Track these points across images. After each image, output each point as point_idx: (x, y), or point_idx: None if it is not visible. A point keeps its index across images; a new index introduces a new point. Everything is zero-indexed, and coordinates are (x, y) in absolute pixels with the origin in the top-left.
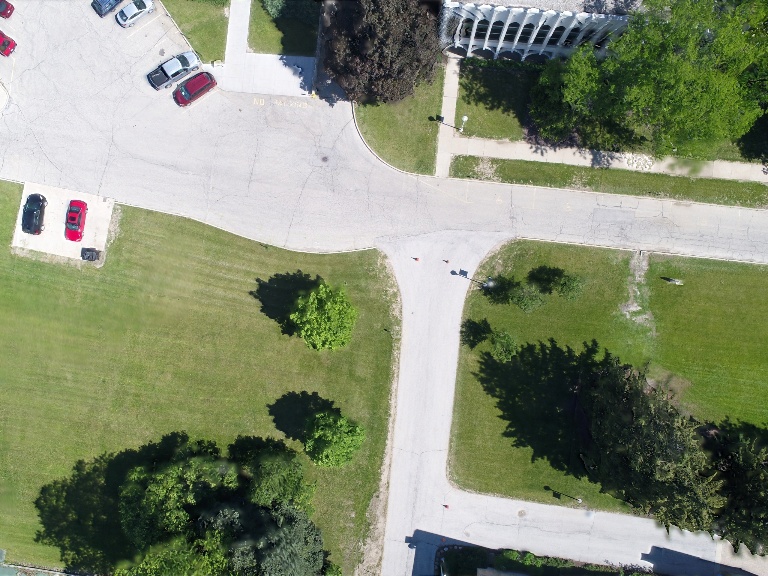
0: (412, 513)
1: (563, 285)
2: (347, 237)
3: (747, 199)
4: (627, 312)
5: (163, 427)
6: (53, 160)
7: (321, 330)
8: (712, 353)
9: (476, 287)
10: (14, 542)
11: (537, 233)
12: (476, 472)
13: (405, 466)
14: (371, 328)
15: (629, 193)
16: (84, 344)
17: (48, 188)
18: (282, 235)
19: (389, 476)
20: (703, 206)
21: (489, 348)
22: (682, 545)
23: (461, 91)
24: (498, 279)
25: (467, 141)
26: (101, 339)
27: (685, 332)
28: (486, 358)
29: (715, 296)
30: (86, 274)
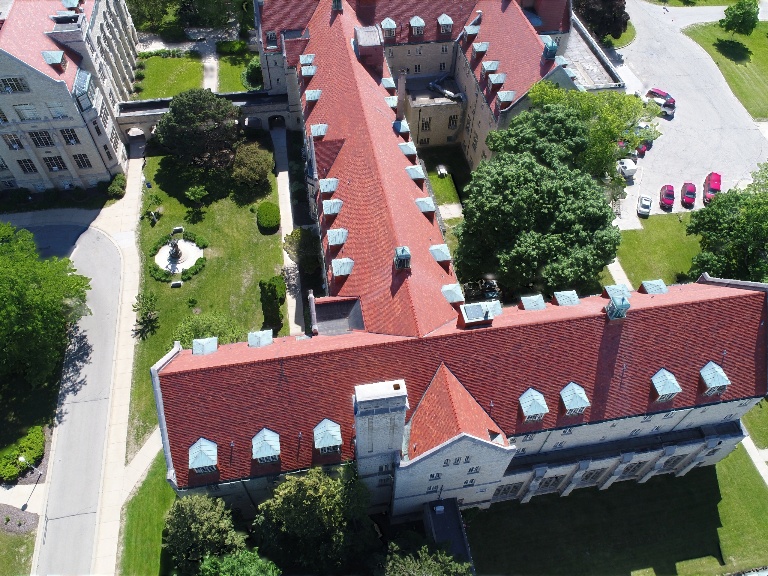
0: None
1: None
2: (684, 41)
3: None
4: None
5: None
6: (759, 152)
7: None
8: None
9: (667, 5)
10: None
11: None
12: None
13: None
14: None
15: None
16: None
17: None
18: (705, 60)
19: None
20: None
21: None
22: None
23: None
24: None
25: None
26: None
27: None
28: None
29: None
30: None
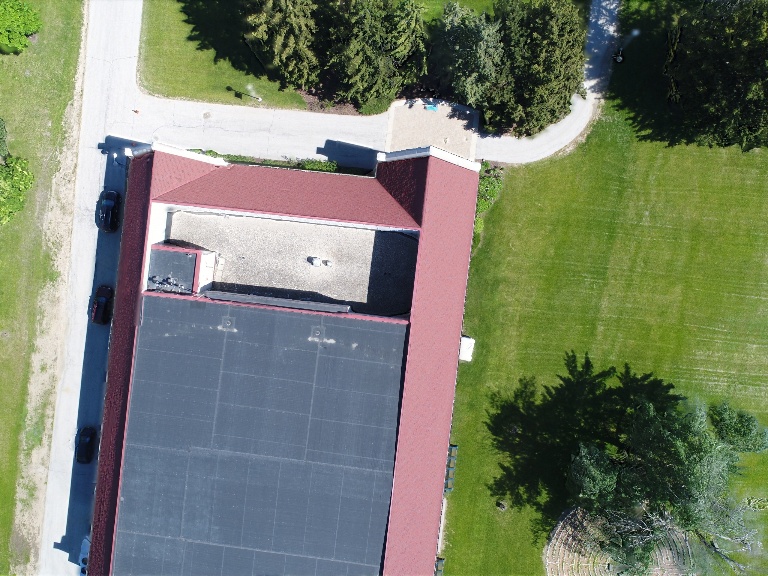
0: (105, 120)
1: None
2: None
3: None
4: None
5: None
6: None
7: None
8: None
9: None
10: None
11: None
12: (164, 77)
13: (98, 74)
14: None
15: None
16: None
17: None
18: None
19: (83, 84)
20: None
21: None
22: (355, 137)
23: None
24: None
25: None
26: None
27: None
28: None
29: None
30: None
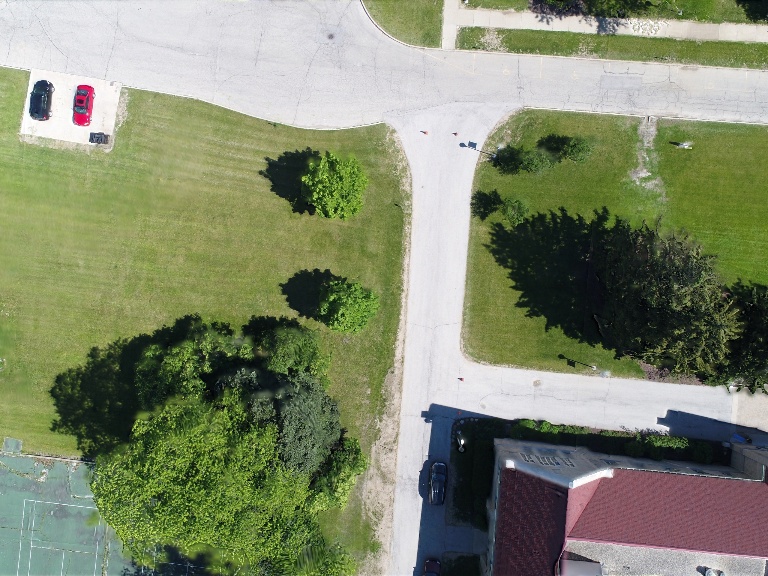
0: (427, 387)
1: (573, 147)
2: (355, 113)
3: (753, 60)
4: (637, 178)
5: (176, 310)
6: (59, 46)
7: (333, 188)
8: (722, 216)
9: (485, 158)
10: (30, 432)
11: (545, 102)
12: (490, 344)
13: (419, 341)
14: (382, 203)
15: (636, 59)
16: (95, 230)
17: (55, 74)
18: (290, 113)
19: (403, 351)
20: (710, 69)
21: (500, 219)
22: (697, 408)
23: None
24: (507, 150)
25: (473, 12)
26: (112, 224)
27: (695, 196)
28: (497, 229)
29: (724, 159)
30: (95, 159)
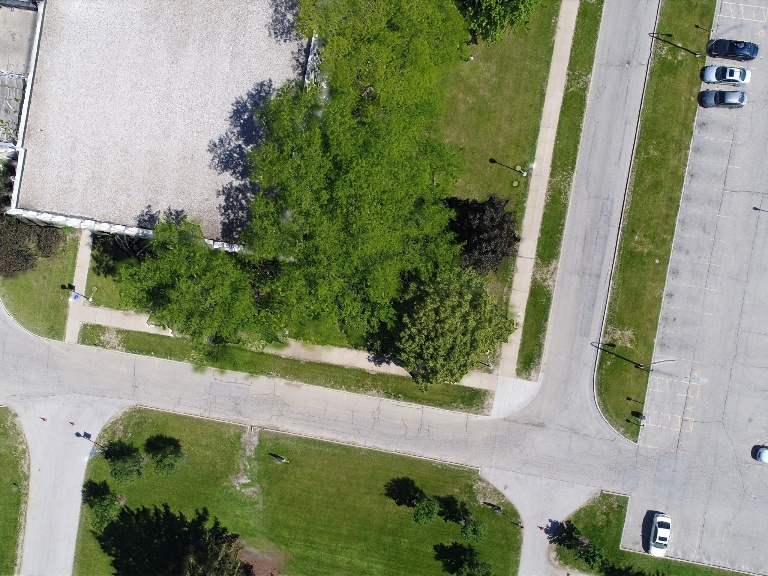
0: None
1: (159, 462)
2: None
3: (352, 385)
4: (237, 484)
5: None
6: None
7: None
8: (314, 529)
9: (98, 450)
10: None
11: (157, 402)
12: None
13: None
14: (1, 481)
15: (243, 371)
16: None
17: None
18: None
19: None
20: (312, 388)
21: None
22: None
23: (92, 262)
24: (118, 444)
25: (95, 310)
26: None
27: (290, 507)
28: None
29: (318, 475)
30: None
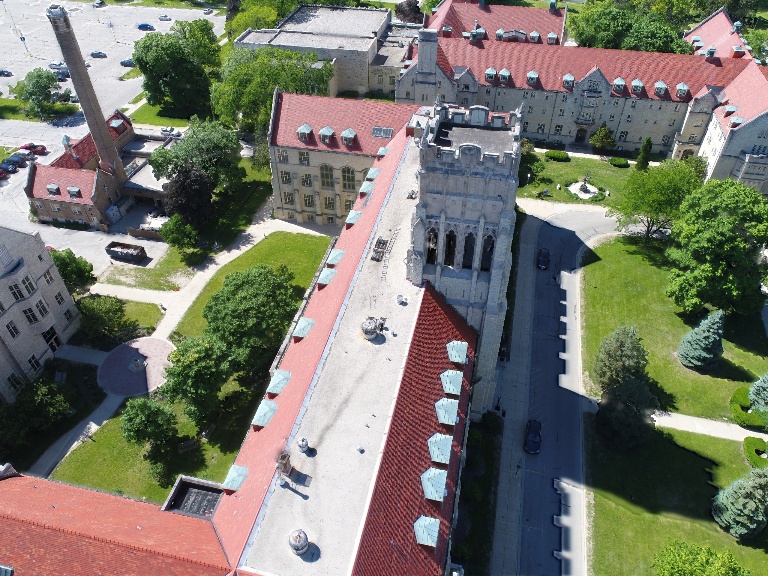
0: None
1: None
2: None
3: None
4: None
5: None
6: None
7: None
8: None
9: None
10: None
11: None
12: None
13: None
14: None
15: None
16: None
17: None
18: None
19: (420, 5)
20: None
21: None
22: None
23: None
24: None
25: None
26: None
27: None
28: None
29: None
30: None
